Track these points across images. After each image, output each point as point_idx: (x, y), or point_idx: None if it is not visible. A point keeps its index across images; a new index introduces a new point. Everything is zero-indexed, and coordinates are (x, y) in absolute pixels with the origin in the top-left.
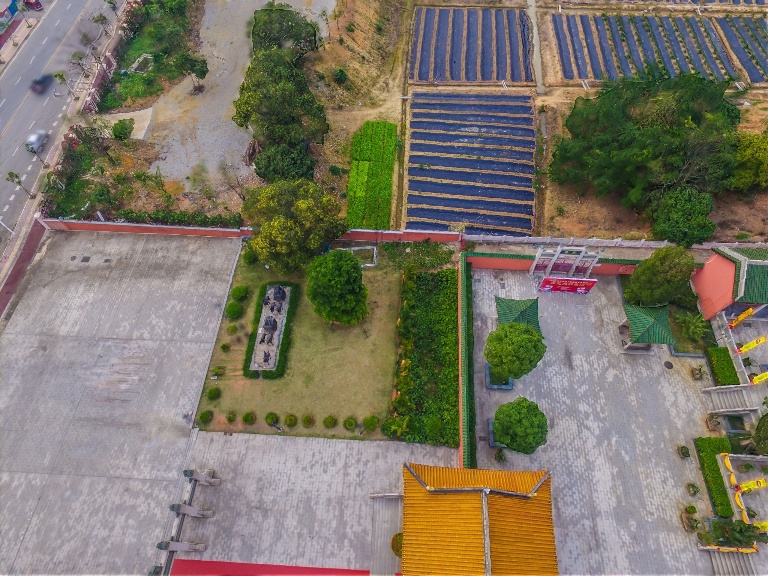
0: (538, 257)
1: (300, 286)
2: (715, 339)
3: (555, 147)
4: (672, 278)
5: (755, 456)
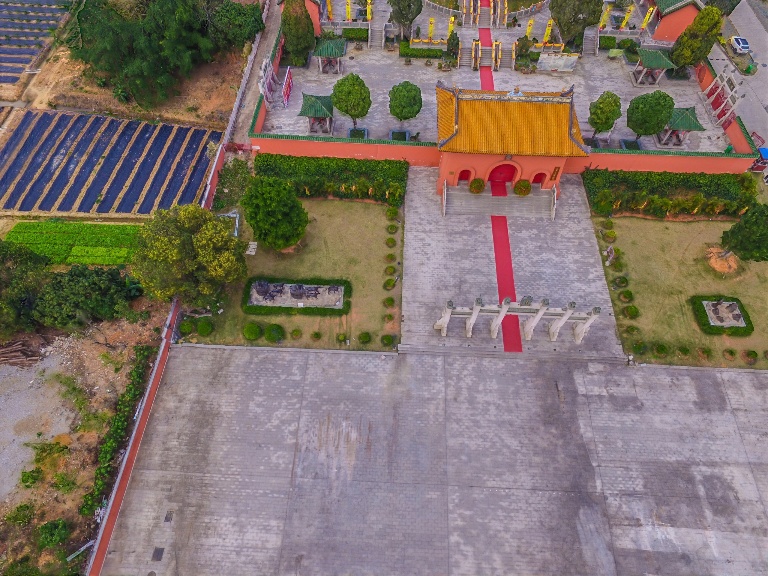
0: (263, 92)
1: (252, 277)
2: (335, 35)
3: (112, 103)
4: (306, 14)
5: None
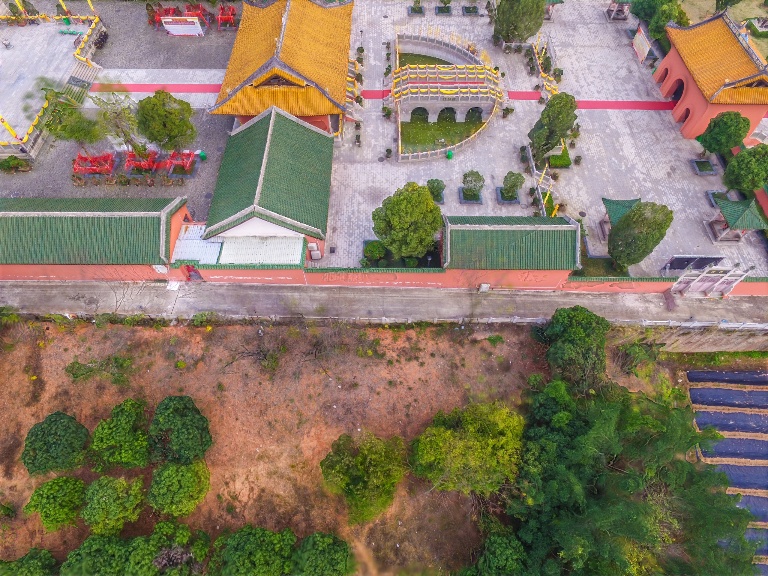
0: None
1: None
2: None
3: None
4: None
5: None
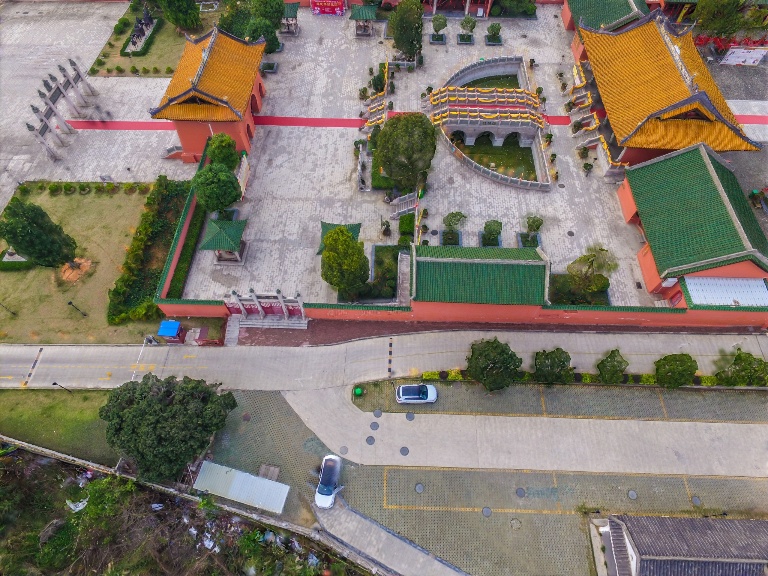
0: None
1: (164, 20)
2: None
3: None
4: None
5: (403, 62)
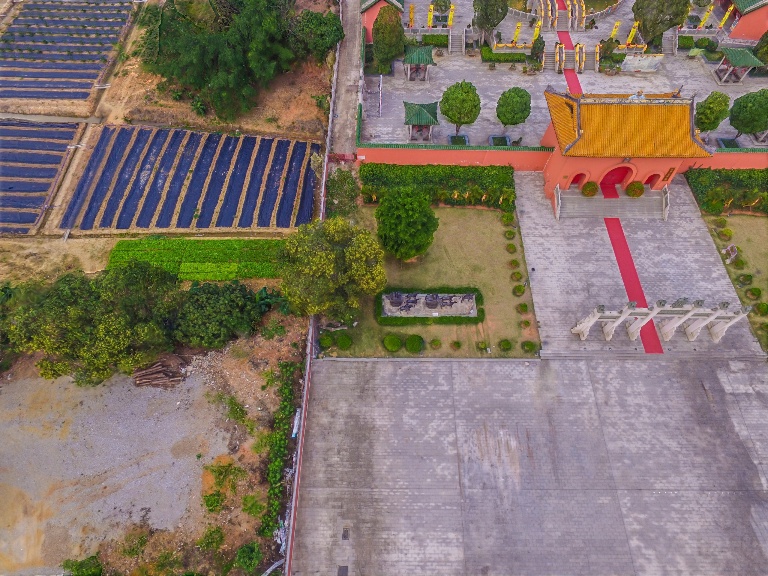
0: None
1: None
2: None
3: (189, 116)
4: (400, 22)
5: None
